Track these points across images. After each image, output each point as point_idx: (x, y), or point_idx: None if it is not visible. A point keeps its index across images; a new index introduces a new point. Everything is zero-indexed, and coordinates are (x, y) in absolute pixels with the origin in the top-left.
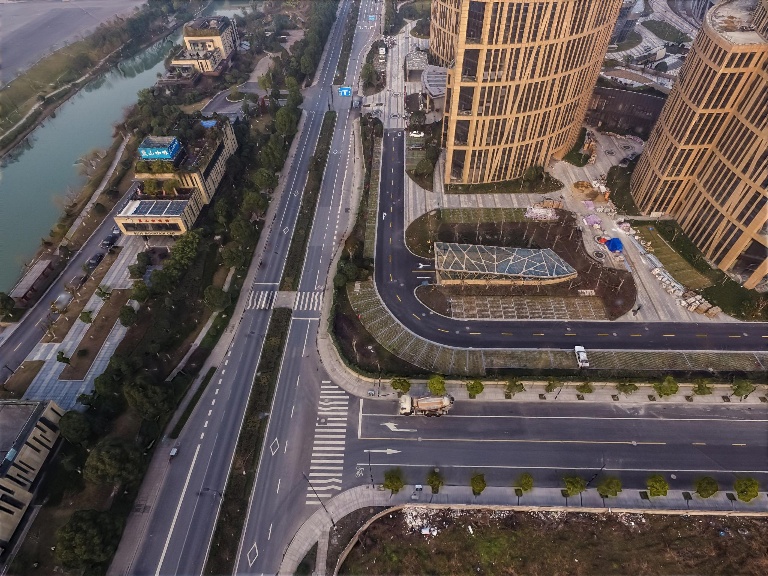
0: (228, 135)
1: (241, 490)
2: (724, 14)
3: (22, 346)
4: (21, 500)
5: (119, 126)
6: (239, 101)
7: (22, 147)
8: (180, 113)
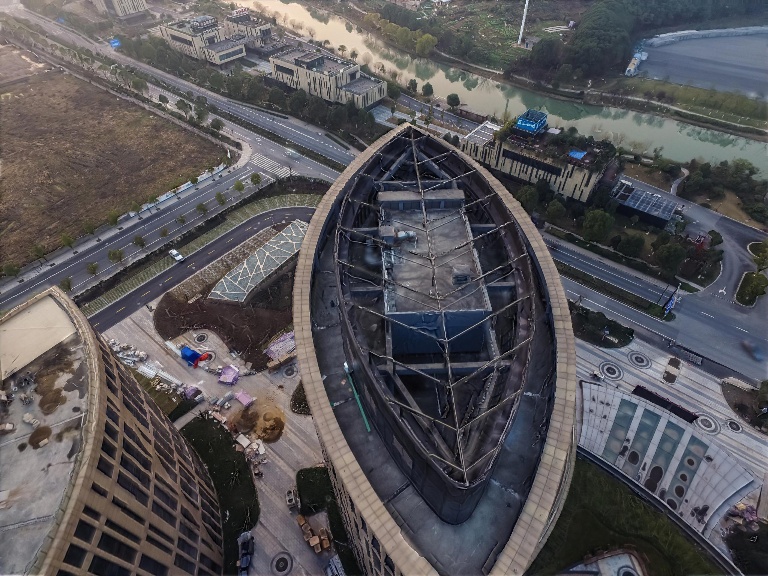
0: (576, 178)
1: (281, 141)
2: (58, 449)
3: (427, 111)
4: (331, 97)
5: (694, 161)
6: (748, 250)
7: (720, 140)
8: (610, 144)
